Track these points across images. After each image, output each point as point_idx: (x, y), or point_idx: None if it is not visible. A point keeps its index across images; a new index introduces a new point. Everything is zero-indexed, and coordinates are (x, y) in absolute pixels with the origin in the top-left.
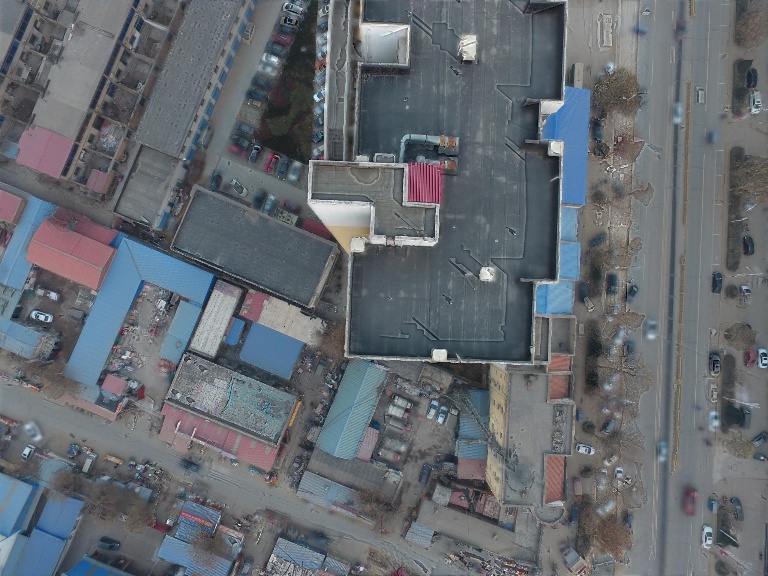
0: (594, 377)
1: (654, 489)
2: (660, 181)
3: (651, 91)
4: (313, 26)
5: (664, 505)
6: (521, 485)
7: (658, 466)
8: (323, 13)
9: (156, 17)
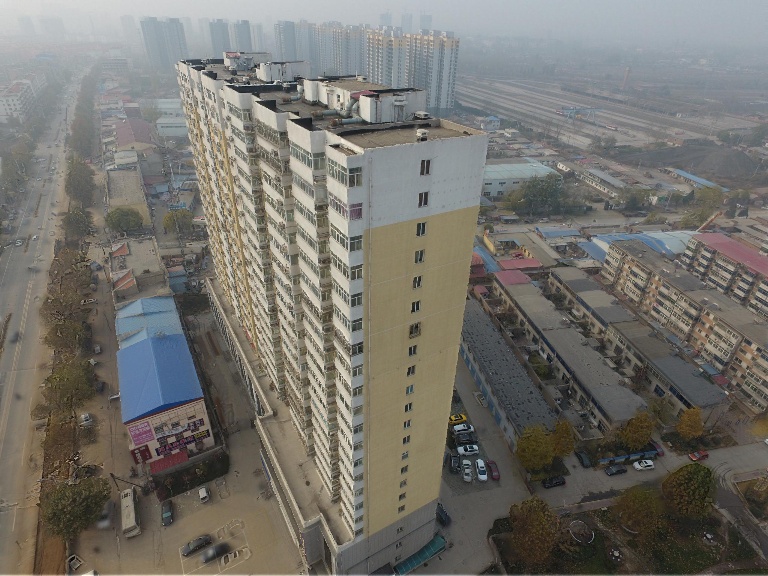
0: (85, 326)
1: (28, 303)
2: (3, 479)
3: (8, 572)
4: None
5: (20, 300)
6: (143, 244)
7: (24, 312)
8: None
9: (550, 375)
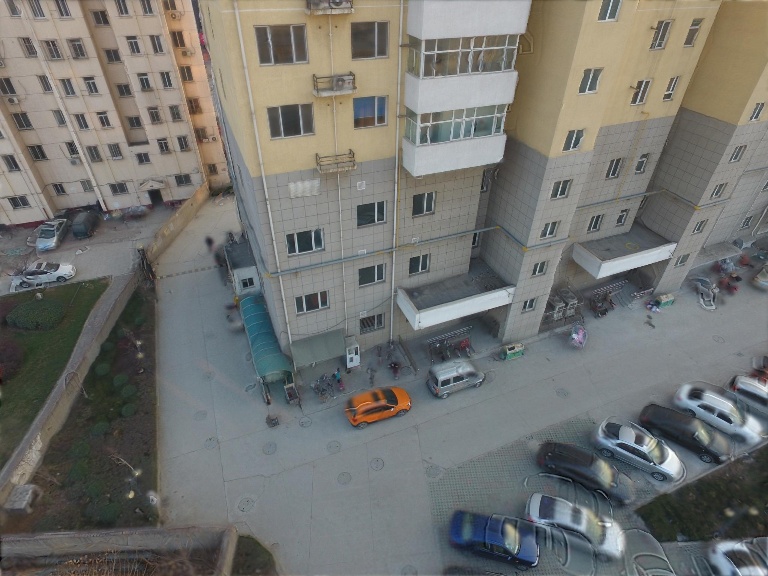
0: None
1: None
2: None
3: None
4: (736, 481)
5: None
6: None
7: None
8: (668, 454)
9: None
